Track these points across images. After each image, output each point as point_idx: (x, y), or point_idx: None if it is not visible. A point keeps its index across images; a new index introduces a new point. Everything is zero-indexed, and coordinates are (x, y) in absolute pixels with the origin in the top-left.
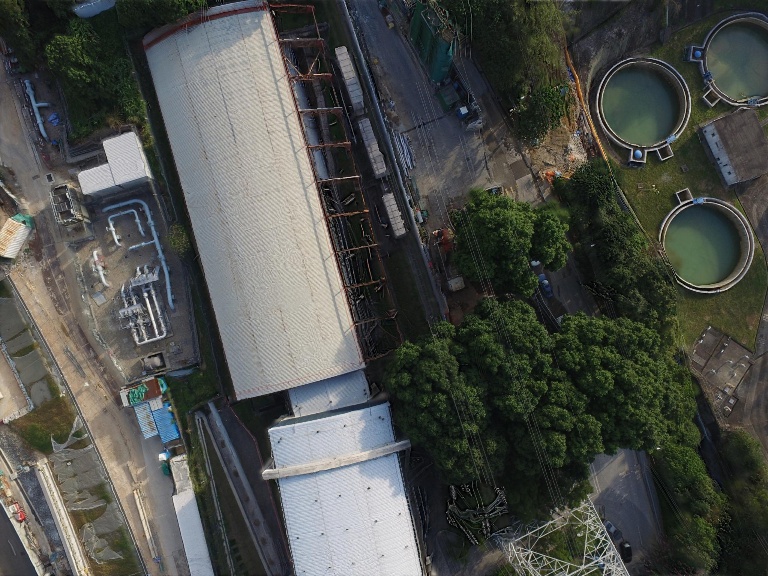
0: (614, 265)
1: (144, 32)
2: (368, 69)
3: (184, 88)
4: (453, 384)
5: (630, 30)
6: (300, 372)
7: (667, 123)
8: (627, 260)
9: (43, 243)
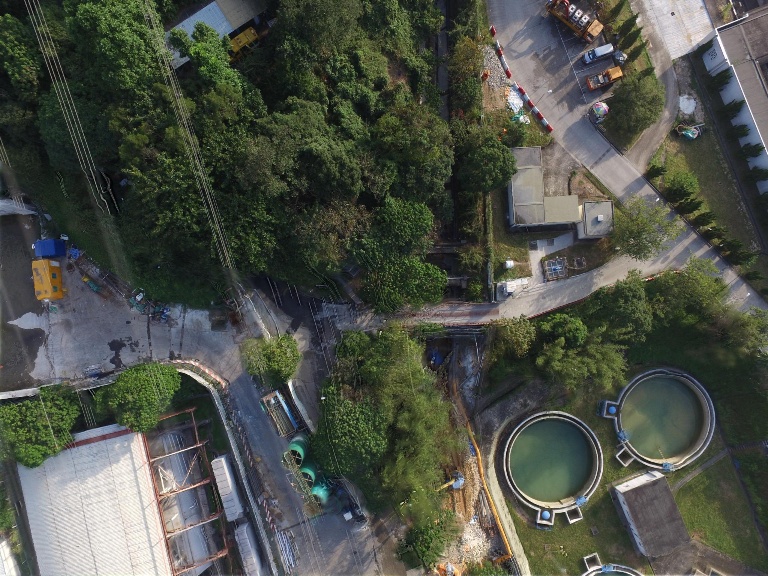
0: None
1: None
2: (246, 480)
3: (49, 510)
4: None
5: (536, 400)
6: None
7: (580, 474)
8: None
9: None
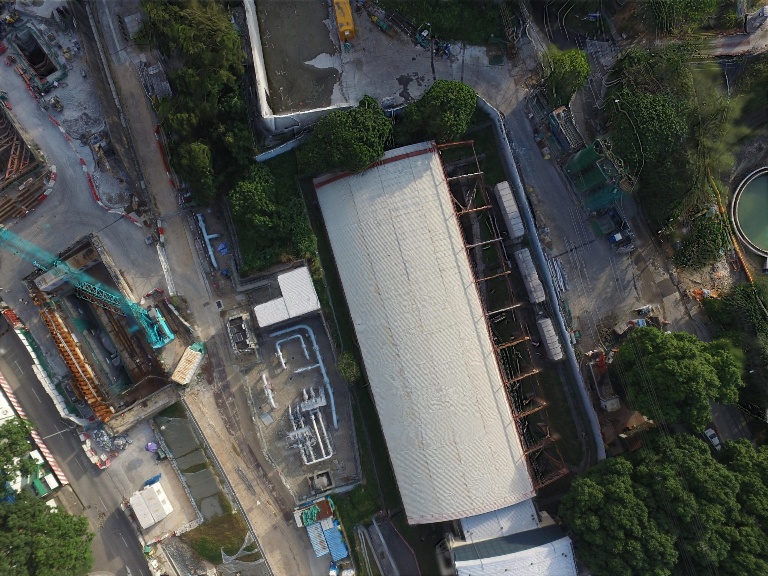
0: None
1: (320, 175)
2: (528, 201)
3: (357, 227)
4: (644, 531)
5: None
6: (475, 502)
7: None
8: None
9: (214, 367)
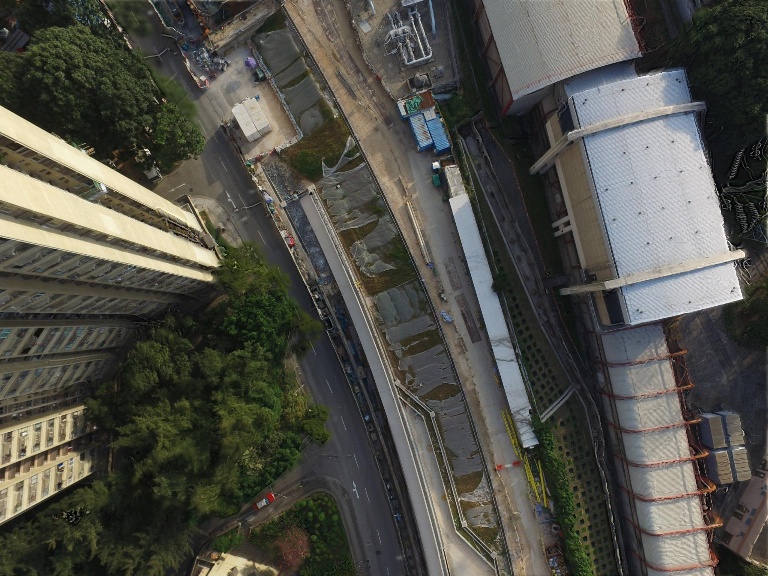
0: None
1: None
2: None
3: None
4: (764, 25)
5: None
6: (583, 59)
7: None
8: None
9: None
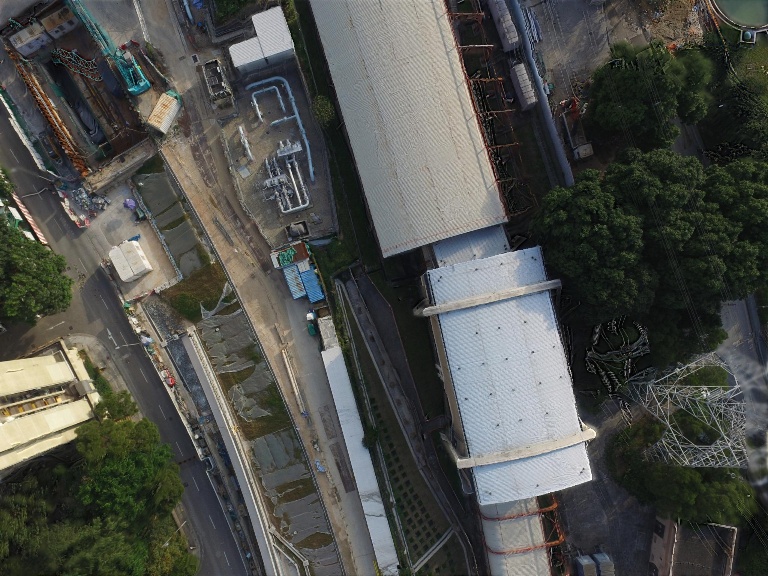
0: (745, 121)
1: None
2: None
3: None
4: (610, 216)
5: None
6: (448, 225)
7: None
8: (758, 115)
9: (191, 120)
